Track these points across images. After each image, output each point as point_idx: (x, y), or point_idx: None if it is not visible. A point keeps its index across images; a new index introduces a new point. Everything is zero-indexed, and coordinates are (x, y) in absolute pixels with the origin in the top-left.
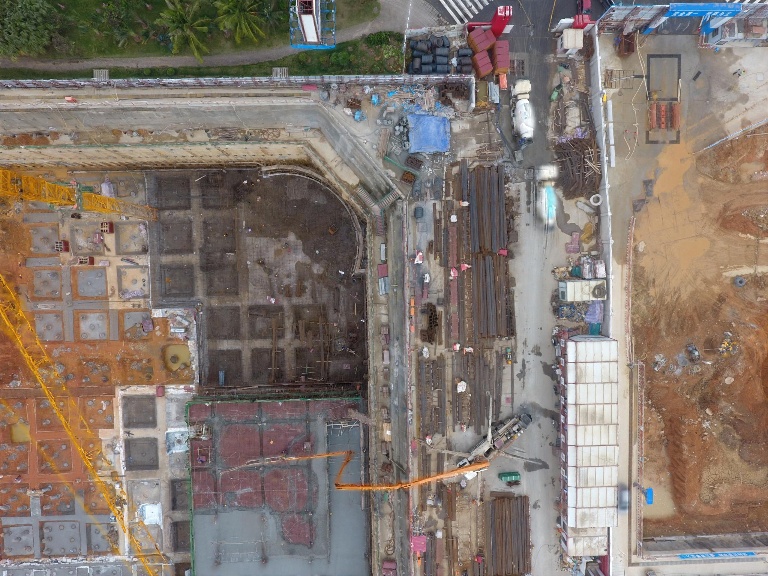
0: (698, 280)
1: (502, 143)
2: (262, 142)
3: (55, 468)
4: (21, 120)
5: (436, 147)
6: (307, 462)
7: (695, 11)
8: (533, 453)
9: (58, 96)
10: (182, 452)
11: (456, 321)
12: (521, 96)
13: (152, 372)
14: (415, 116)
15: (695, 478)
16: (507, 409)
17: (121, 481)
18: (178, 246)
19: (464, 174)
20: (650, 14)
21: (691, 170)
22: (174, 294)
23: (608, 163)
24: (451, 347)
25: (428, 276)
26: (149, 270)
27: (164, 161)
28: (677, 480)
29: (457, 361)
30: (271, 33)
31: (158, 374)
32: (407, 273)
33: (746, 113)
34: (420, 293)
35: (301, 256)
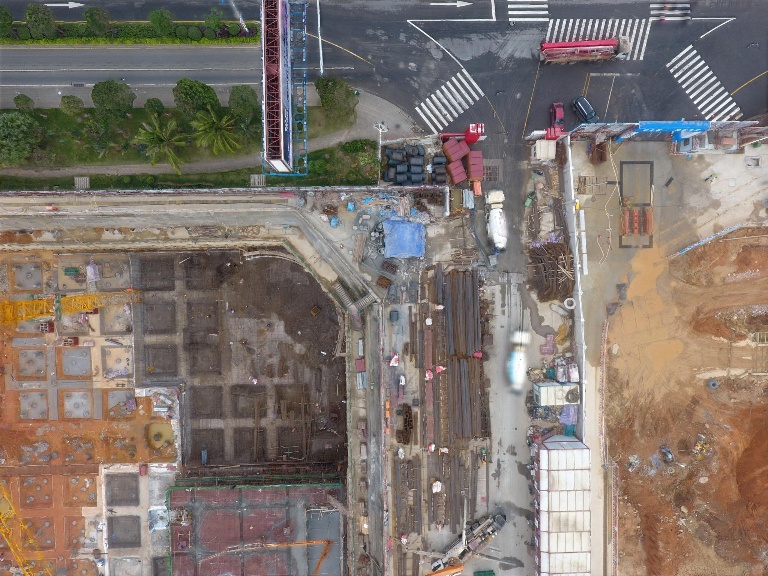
0: (672, 382)
1: (477, 247)
2: (241, 240)
3: (38, 545)
4: (4, 224)
5: (411, 253)
6: (287, 547)
7: (664, 128)
8: (508, 552)
9: (40, 203)
10: (164, 529)
11: (431, 422)
12: (494, 206)
13: (135, 450)
14: (391, 222)
15: (671, 575)
16: (482, 508)
17: (103, 559)
18: (162, 326)
19: (439, 278)
20: (621, 128)
21: (664, 274)
22: (158, 373)
23: (581, 269)
24: (426, 447)
25: (403, 378)
26: (133, 350)
27: (148, 247)
28: (653, 575)
29: (432, 461)
30: (249, 142)
31: (141, 452)
32: (382, 376)
33: (718, 218)
34: (396, 394)
35: (283, 336)
